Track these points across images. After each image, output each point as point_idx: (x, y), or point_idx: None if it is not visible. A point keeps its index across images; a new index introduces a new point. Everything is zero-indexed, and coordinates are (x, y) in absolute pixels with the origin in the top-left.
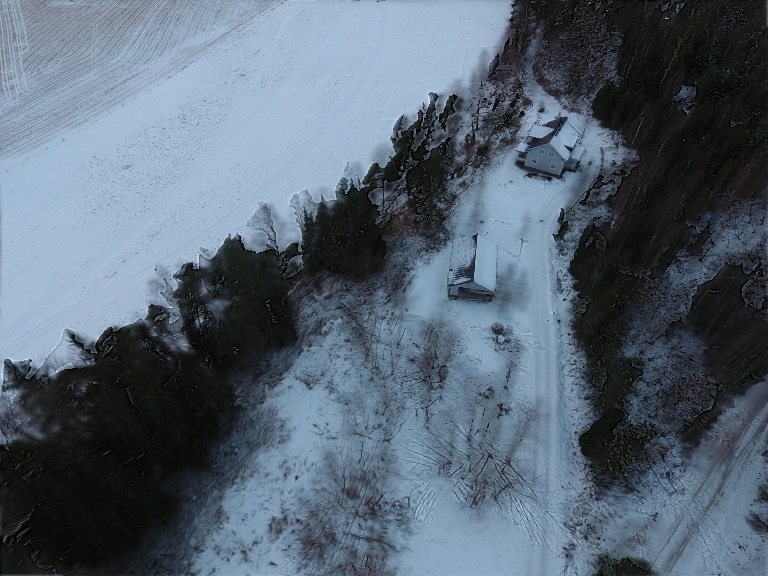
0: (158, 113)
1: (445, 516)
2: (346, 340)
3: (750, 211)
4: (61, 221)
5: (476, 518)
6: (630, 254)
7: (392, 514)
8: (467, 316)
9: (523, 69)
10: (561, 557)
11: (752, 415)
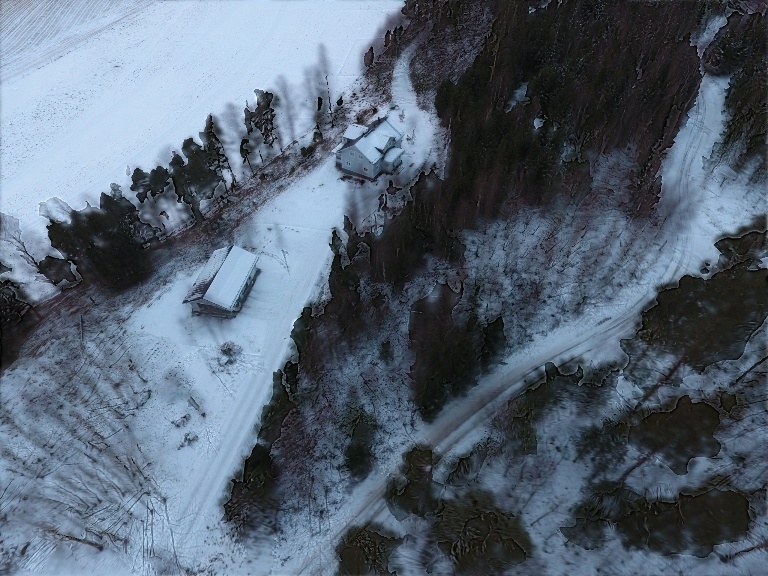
0: (12, 107)
1: (58, 564)
2: (57, 362)
3: (529, 220)
4: None
5: (91, 566)
6: (388, 266)
7: None
8: (202, 334)
9: (401, 63)
10: None
11: (432, 445)
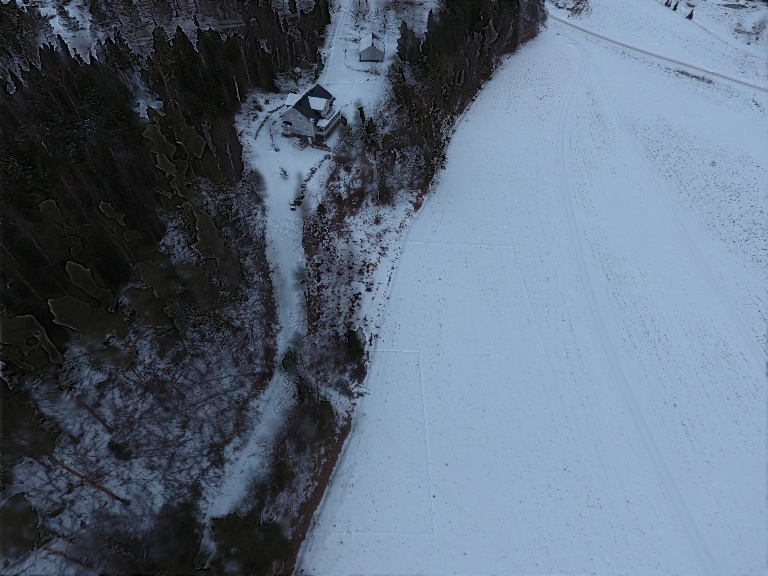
0: None
1: None
2: None
3: None
4: (677, 119)
5: None
6: None
7: (390, 6)
8: None
9: (294, 366)
10: (343, 7)
11: None
